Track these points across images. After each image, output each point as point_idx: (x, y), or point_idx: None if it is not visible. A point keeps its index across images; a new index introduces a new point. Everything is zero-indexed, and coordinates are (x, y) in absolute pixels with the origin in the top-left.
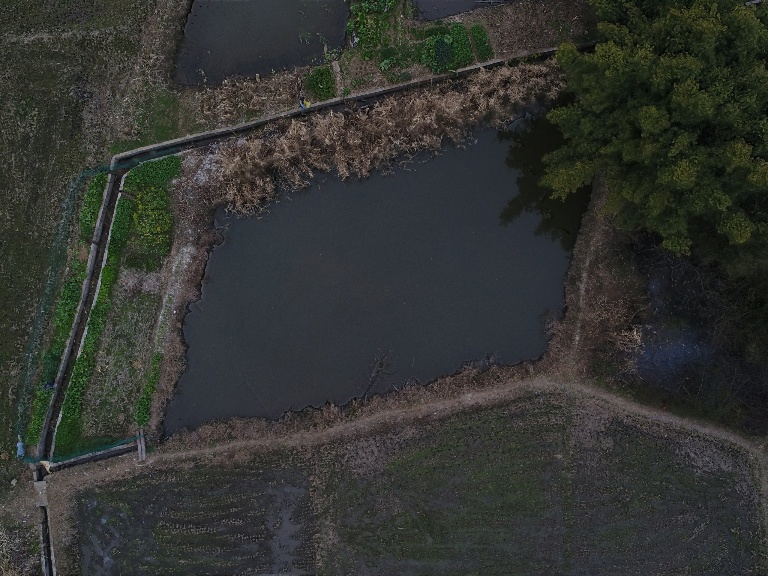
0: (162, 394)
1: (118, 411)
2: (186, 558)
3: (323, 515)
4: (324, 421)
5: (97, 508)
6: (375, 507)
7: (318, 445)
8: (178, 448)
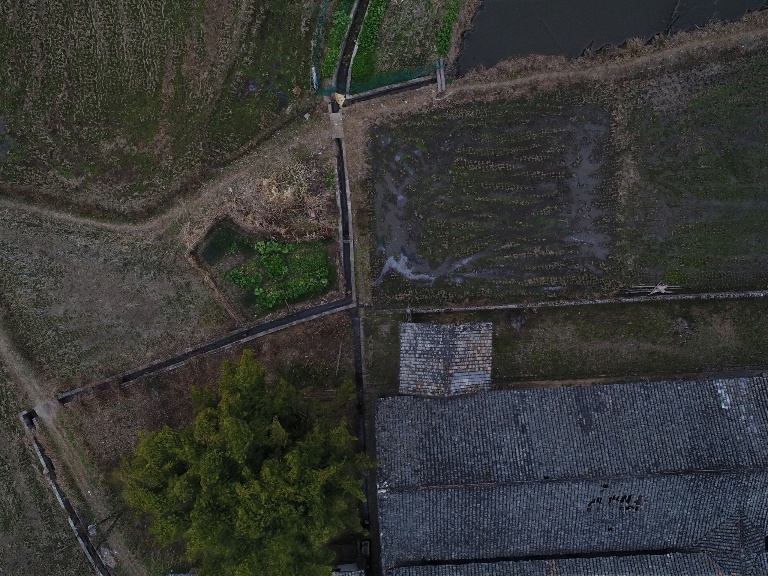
0: (460, 28)
1: (413, 46)
2: (483, 196)
3: (624, 152)
4: (631, 51)
5: (391, 145)
6: (678, 145)
7: (621, 79)
8: (478, 80)
